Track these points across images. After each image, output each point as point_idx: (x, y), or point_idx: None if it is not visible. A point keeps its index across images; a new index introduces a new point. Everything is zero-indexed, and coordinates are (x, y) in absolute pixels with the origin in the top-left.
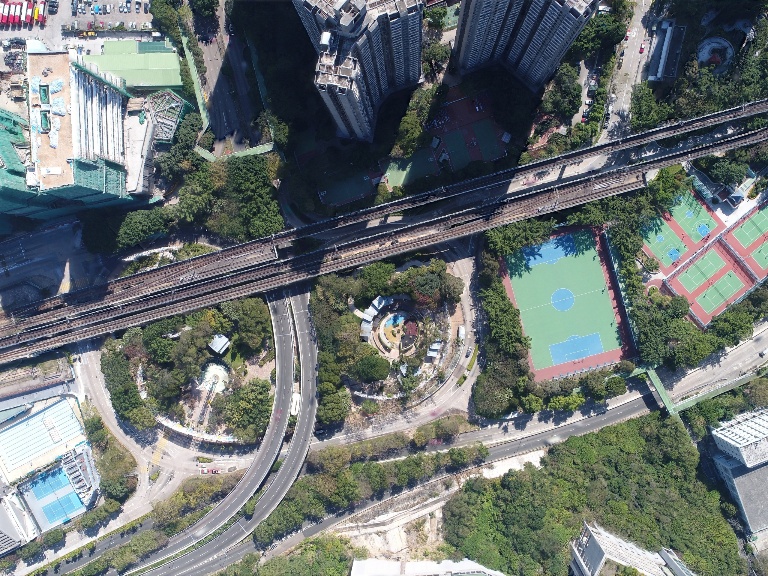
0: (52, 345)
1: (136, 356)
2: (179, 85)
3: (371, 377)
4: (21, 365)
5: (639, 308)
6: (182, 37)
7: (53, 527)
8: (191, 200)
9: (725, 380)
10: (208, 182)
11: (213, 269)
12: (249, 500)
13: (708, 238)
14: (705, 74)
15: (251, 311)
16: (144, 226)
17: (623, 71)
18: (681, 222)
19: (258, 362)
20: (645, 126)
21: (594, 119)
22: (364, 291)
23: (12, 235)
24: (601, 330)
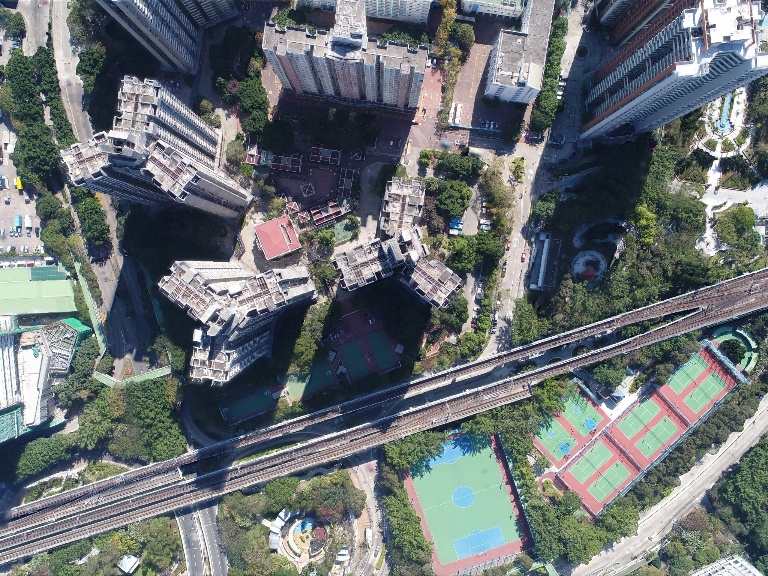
0: None
1: None
2: (74, 311)
3: None
4: None
5: (533, 506)
6: (75, 263)
7: None
8: (91, 429)
9: (618, 564)
10: (107, 411)
11: (118, 492)
12: None
13: (595, 431)
14: (579, 290)
15: (158, 533)
16: (44, 456)
17: (507, 279)
18: (569, 418)
19: (170, 574)
20: (527, 340)
21: (481, 330)
22: (269, 507)
23: None
24: (501, 523)
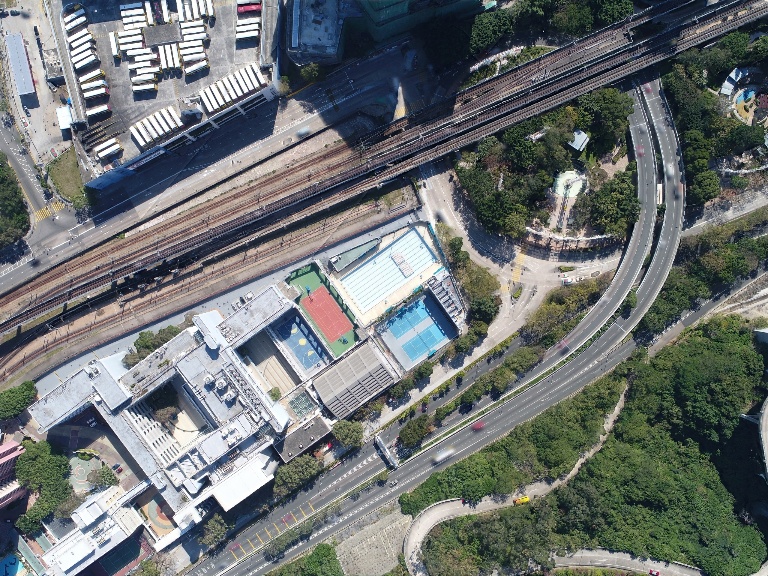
0: (402, 170)
1: (495, 166)
2: None
3: (748, 144)
4: (363, 201)
5: None
6: None
7: (418, 363)
8: None
9: None
10: None
11: (565, 64)
12: (627, 296)
13: None
14: None
15: (614, 99)
16: (495, 26)
17: None
18: None
19: (611, 159)
20: None
21: None
22: (726, 62)
23: (341, 64)
24: None
